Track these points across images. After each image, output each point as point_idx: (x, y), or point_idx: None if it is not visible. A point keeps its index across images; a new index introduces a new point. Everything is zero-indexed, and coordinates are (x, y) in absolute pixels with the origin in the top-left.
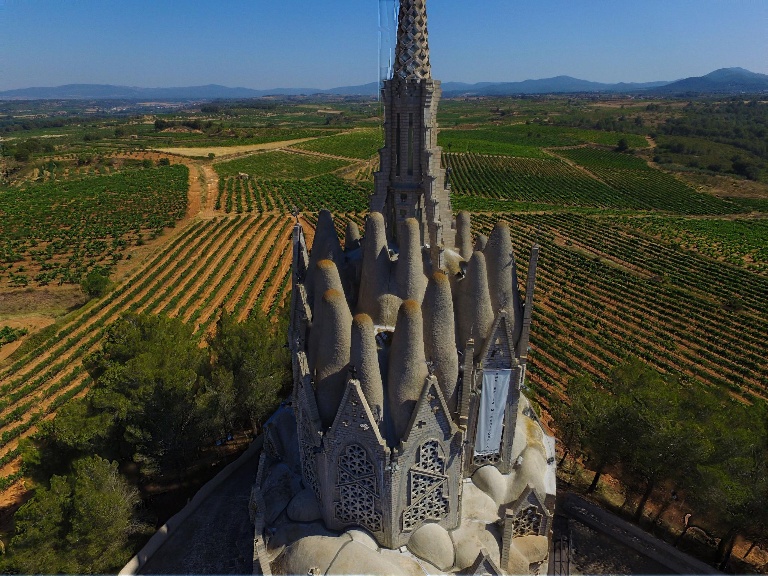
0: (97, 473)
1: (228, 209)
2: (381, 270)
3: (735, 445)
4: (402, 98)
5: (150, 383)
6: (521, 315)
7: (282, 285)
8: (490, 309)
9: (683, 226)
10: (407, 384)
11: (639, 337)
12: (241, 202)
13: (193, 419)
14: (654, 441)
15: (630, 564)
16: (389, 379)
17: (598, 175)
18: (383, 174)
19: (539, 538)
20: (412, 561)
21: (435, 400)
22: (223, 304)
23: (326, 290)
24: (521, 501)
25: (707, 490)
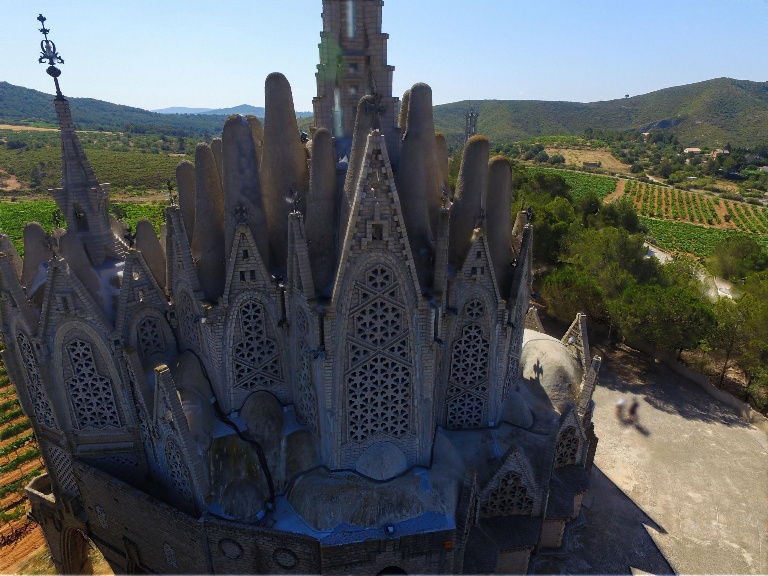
0: None
1: None
2: None
3: None
4: None
5: None
6: None
7: None
8: None
9: None
10: None
11: None
12: None
13: None
14: None
15: None
16: None
17: None
18: None
19: None
20: None
21: None
22: None
23: None
24: None
25: None
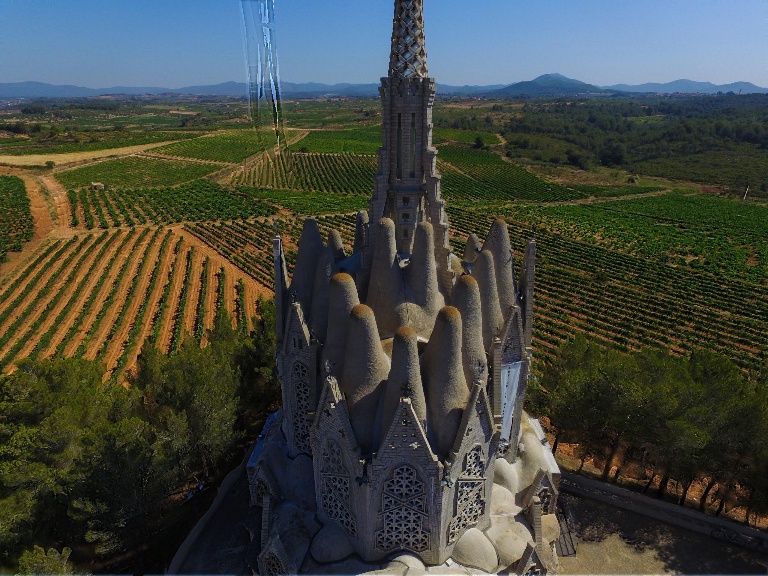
0: (49, 569)
1: (89, 225)
2: (396, 278)
3: (691, 398)
4: (404, 97)
5: (92, 443)
6: (522, 308)
7: (181, 305)
8: (499, 306)
9: (544, 212)
10: (451, 393)
11: (538, 314)
12: (103, 216)
13: (152, 475)
14: (623, 406)
15: (616, 520)
16: (430, 391)
17: (464, 170)
18: (383, 177)
19: (549, 517)
20: (462, 572)
21: (480, 404)
22: (112, 334)
23: (346, 306)
24: (536, 486)
25: (675, 441)
